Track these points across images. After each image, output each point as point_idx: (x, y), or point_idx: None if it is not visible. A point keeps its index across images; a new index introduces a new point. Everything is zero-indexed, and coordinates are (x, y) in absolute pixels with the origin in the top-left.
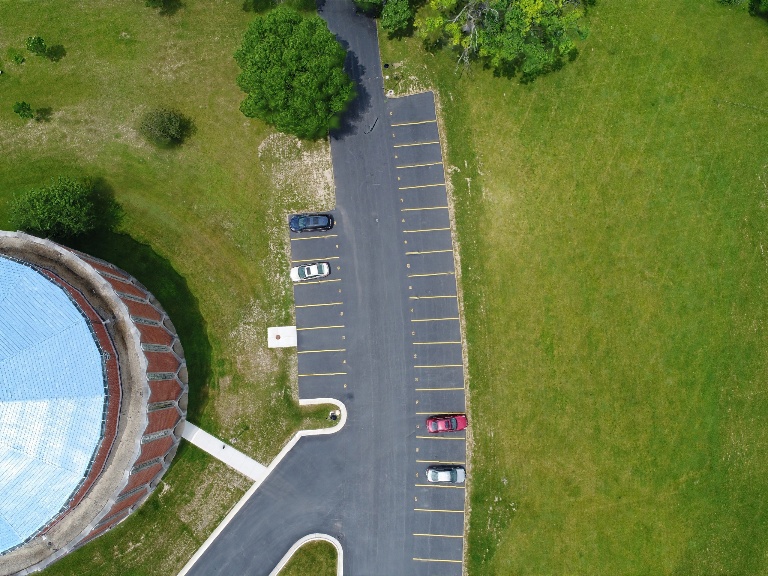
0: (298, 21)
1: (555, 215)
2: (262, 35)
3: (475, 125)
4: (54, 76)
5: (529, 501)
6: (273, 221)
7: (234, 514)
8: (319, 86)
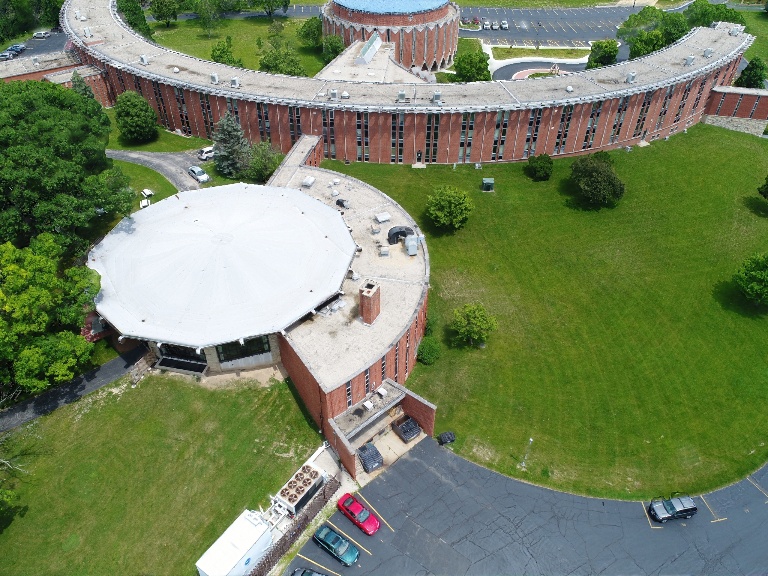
0: None
1: None
2: None
3: None
4: (240, 53)
5: None
6: None
7: None
8: None
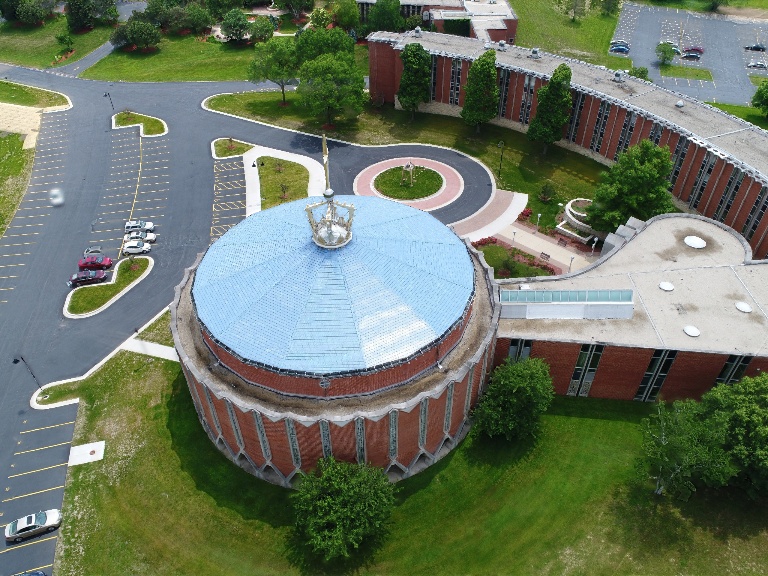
0: None
1: None
2: None
3: None
4: None
5: None
6: None
7: (155, 317)
8: None
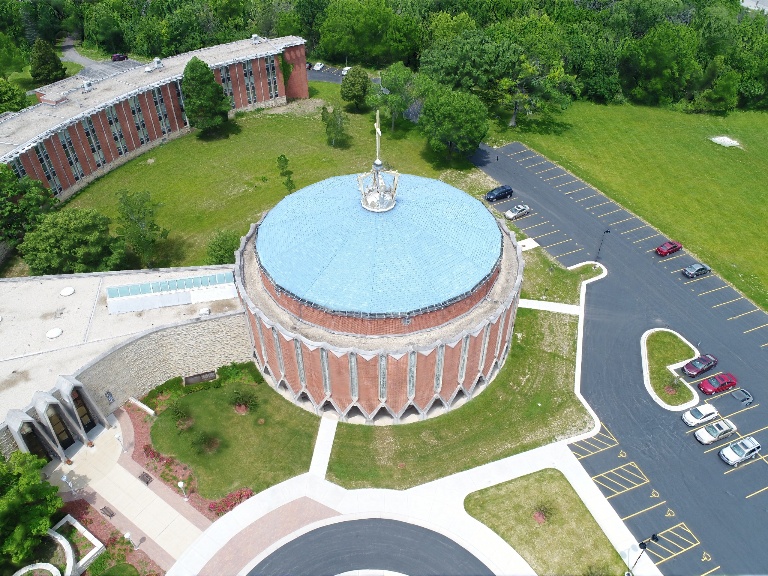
0: None
1: None
2: None
3: None
4: None
5: (759, 272)
6: None
7: (581, 337)
8: None
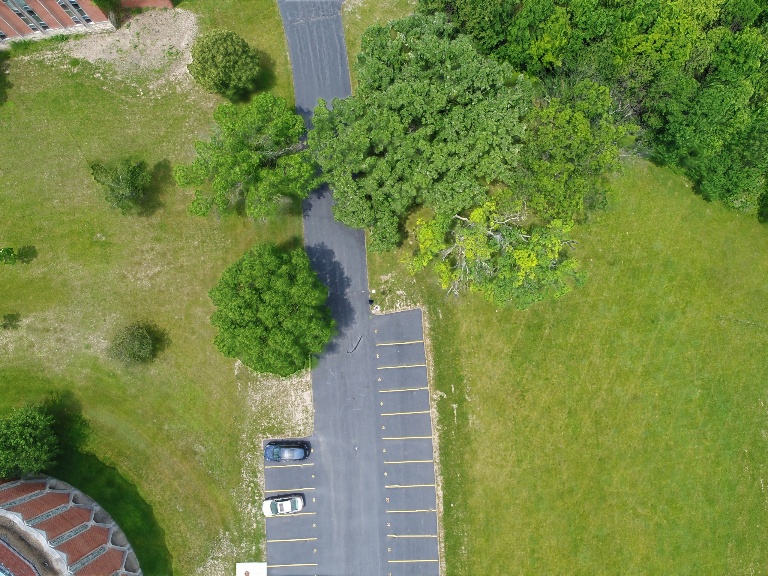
0: (277, 268)
1: (545, 446)
2: (238, 285)
3: (464, 345)
4: (24, 279)
5: None
6: (247, 446)
7: None
8: (296, 341)
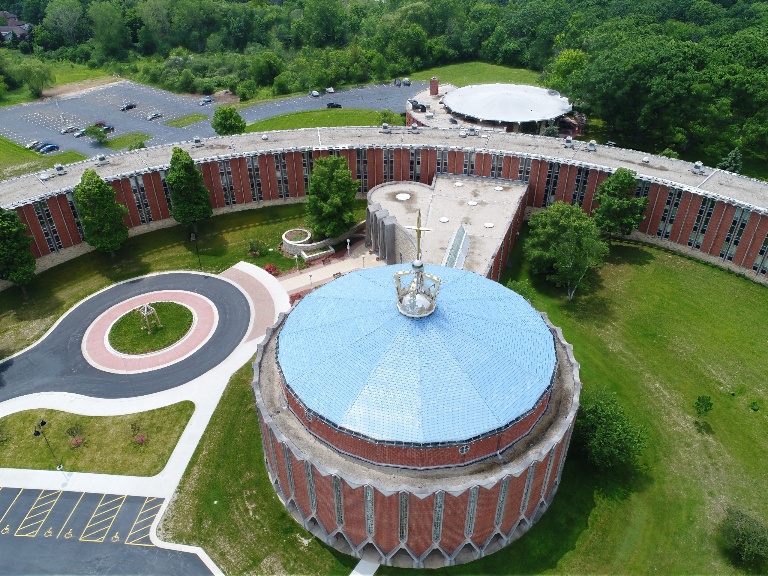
0: None
1: None
2: None
3: None
4: (752, 435)
5: None
6: None
7: None
8: None
